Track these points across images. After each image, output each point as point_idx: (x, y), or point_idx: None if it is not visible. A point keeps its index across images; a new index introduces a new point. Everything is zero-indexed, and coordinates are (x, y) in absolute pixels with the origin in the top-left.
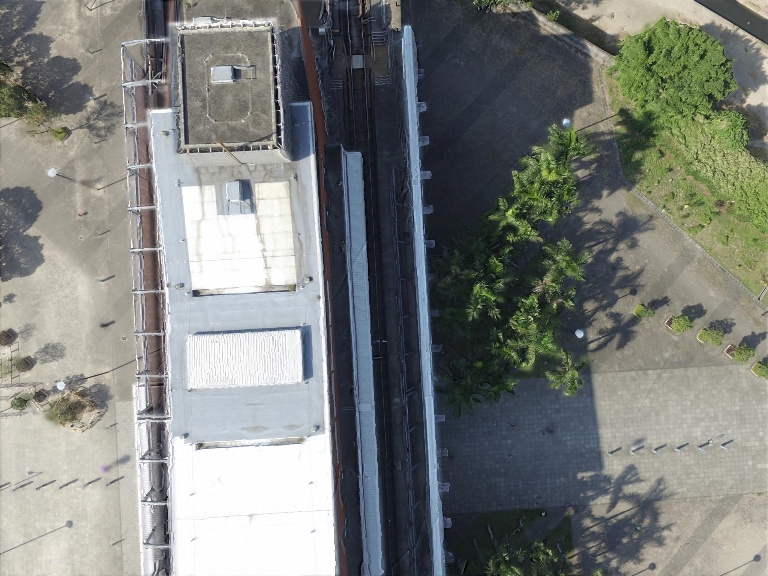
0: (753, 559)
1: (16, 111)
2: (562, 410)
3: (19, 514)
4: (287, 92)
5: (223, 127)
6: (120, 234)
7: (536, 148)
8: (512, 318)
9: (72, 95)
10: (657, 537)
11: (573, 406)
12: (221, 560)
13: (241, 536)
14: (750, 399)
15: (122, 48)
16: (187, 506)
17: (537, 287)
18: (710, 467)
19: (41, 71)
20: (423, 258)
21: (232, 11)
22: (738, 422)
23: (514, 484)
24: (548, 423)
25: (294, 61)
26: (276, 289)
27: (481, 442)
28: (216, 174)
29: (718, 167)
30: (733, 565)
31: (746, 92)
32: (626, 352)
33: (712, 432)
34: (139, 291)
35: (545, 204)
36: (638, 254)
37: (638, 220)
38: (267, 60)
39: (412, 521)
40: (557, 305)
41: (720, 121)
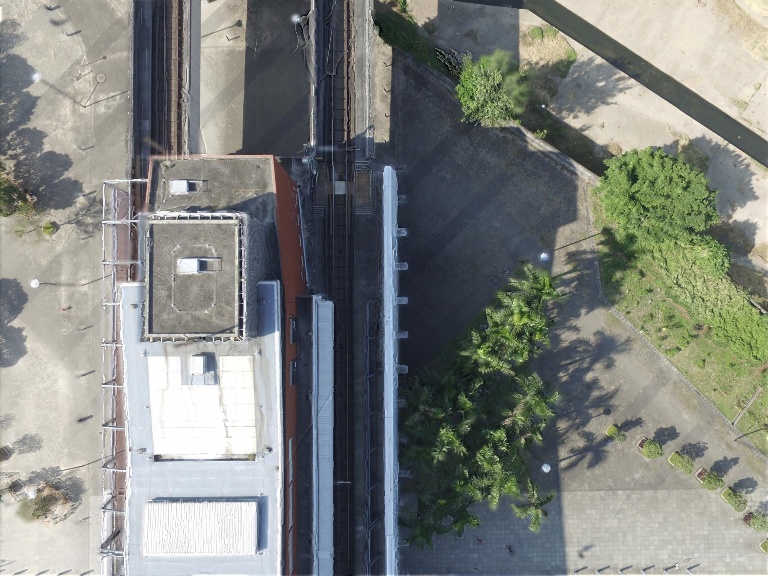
0: None
1: (5, 212)
2: None
3: None
4: (253, 276)
5: (187, 317)
6: (102, 330)
7: (513, 281)
8: (479, 452)
9: (62, 190)
10: None
11: None
12: None
13: None
14: (719, 524)
15: (104, 185)
16: None
17: (506, 420)
18: None
19: (33, 165)
20: (391, 398)
21: (209, 174)
22: (706, 546)
23: None
24: (515, 539)
25: (267, 226)
26: (236, 457)
27: (448, 555)
28: (182, 346)
29: (698, 293)
30: None
31: (733, 208)
32: (597, 471)
33: (679, 555)
34: (108, 427)
35: (516, 345)
36: (614, 374)
37: (615, 340)
38: (233, 253)
39: None
40: (526, 438)
41: (701, 249)
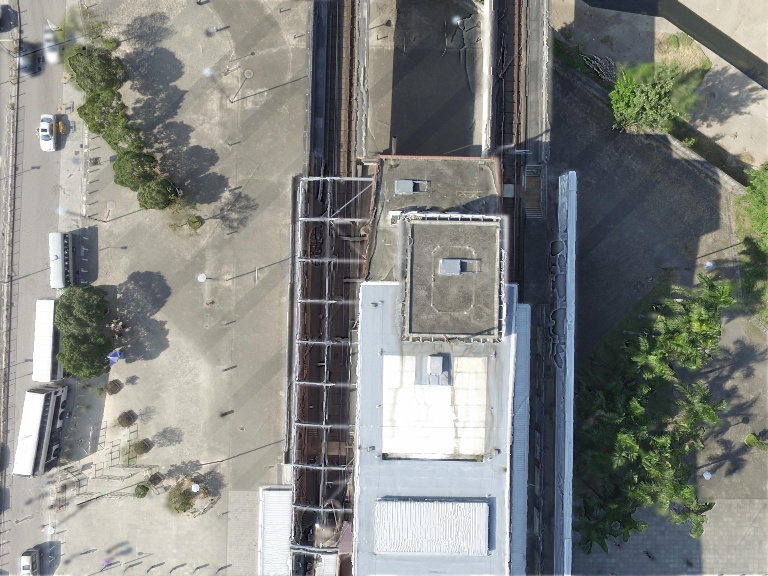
0: None
1: (161, 205)
2: (667, 533)
3: None
4: None
5: (446, 317)
6: (245, 325)
7: (677, 288)
8: (645, 458)
9: (208, 185)
10: None
11: (678, 529)
12: None
13: None
14: None
15: (301, 182)
16: None
17: (669, 426)
18: None
19: (179, 159)
20: (572, 402)
21: (432, 174)
22: None
23: None
24: (653, 545)
25: None
26: (463, 457)
27: (585, 559)
28: (418, 346)
29: None
30: None
31: None
32: (734, 480)
33: None
34: (302, 423)
35: (690, 352)
36: (753, 383)
37: (755, 349)
38: (493, 255)
39: None
40: None
41: None
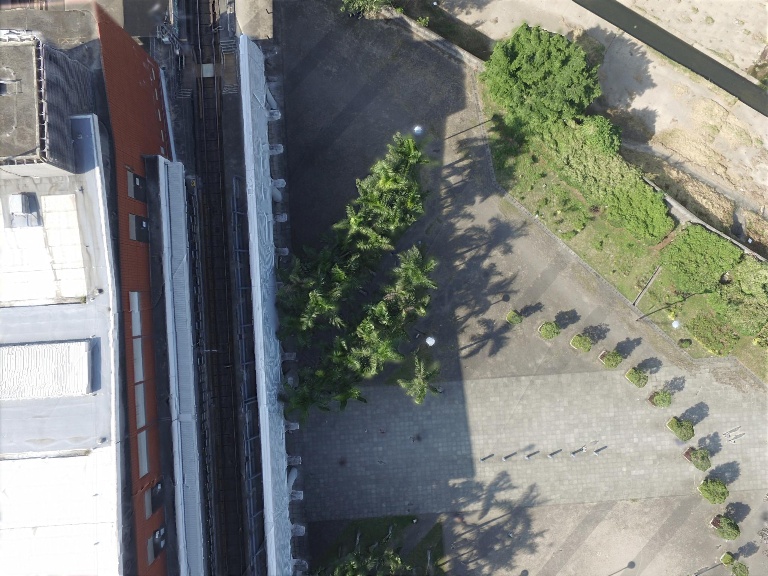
0: (627, 566)
1: None
2: (434, 417)
3: None
4: (63, 105)
5: None
6: None
7: (388, 156)
8: (359, 326)
9: None
10: (530, 544)
11: (445, 413)
12: (4, 572)
13: (24, 548)
14: (624, 405)
15: None
16: None
17: (387, 295)
18: (584, 473)
19: None
20: (258, 267)
21: (33, 24)
22: (612, 428)
23: (385, 491)
24: (419, 430)
25: (94, 73)
26: (68, 301)
27: (352, 449)
28: (1, 187)
29: (589, 172)
30: (607, 572)
31: (631, 96)
32: (499, 358)
33: (586, 438)
34: None
35: (387, 212)
36: (511, 260)
37: (511, 226)
38: (32, 74)
39: (252, 530)
40: (408, 313)
41: (588, 126)
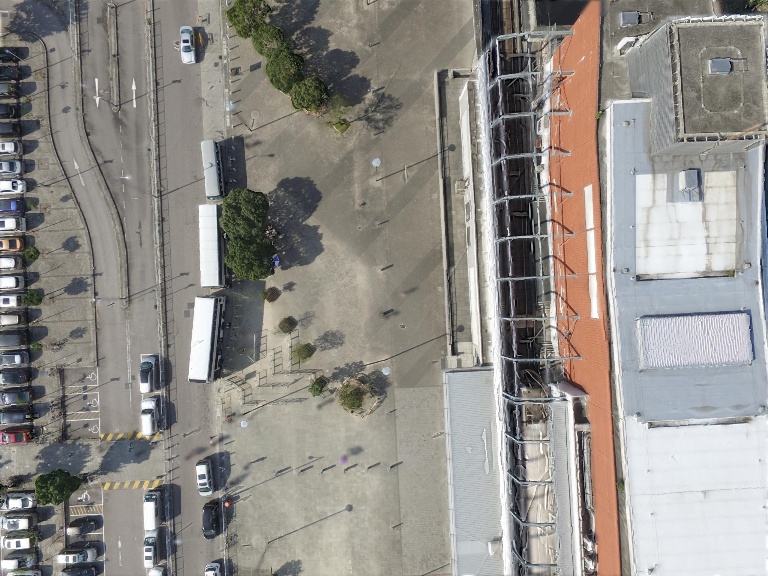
0: None
1: (318, 102)
2: None
3: (300, 498)
4: None
5: (717, 117)
6: (398, 224)
7: None
8: None
9: (351, 87)
10: None
11: None
12: (680, 534)
13: (697, 511)
14: None
15: (497, 41)
16: (645, 482)
17: None
18: None
19: (320, 64)
20: (767, 248)
21: (653, 6)
22: None
23: None
24: None
25: None
26: (713, 274)
27: None
28: (669, 163)
29: None
30: None
31: None
32: None
33: None
34: (519, 277)
35: None
36: None
37: None
38: (759, 53)
39: None
40: None
41: None
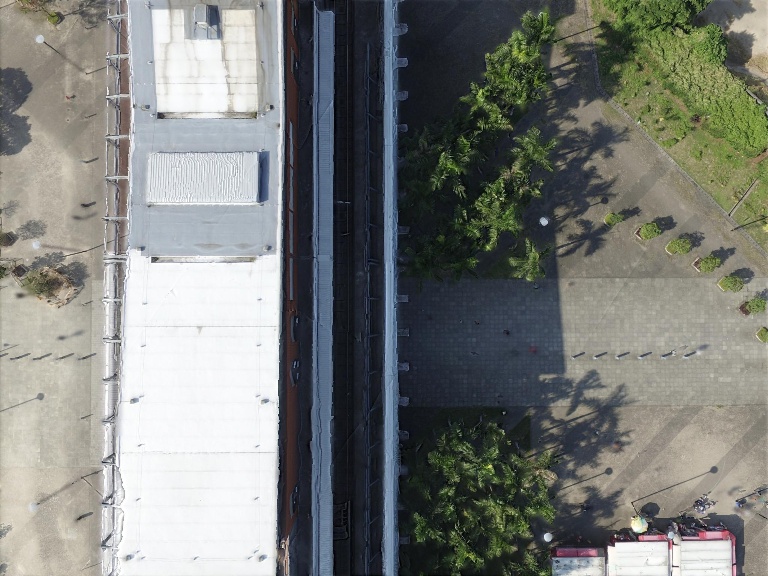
0: (710, 470)
1: None
2: (528, 312)
3: None
4: None
5: None
6: None
7: None
8: (478, 200)
9: None
10: (615, 442)
11: (539, 309)
12: (169, 366)
13: (190, 345)
14: (715, 313)
15: None
16: (140, 314)
17: (505, 174)
18: (672, 377)
19: None
20: (391, 128)
21: None
22: (702, 334)
23: (477, 382)
24: (513, 324)
25: None
26: (238, 117)
27: (446, 338)
28: None
29: (695, 81)
30: (690, 475)
31: (730, 19)
32: (594, 259)
33: (676, 343)
34: (112, 136)
35: (515, 87)
36: (611, 164)
37: (613, 131)
38: None
39: (368, 387)
40: (523, 193)
41: (698, 34)
